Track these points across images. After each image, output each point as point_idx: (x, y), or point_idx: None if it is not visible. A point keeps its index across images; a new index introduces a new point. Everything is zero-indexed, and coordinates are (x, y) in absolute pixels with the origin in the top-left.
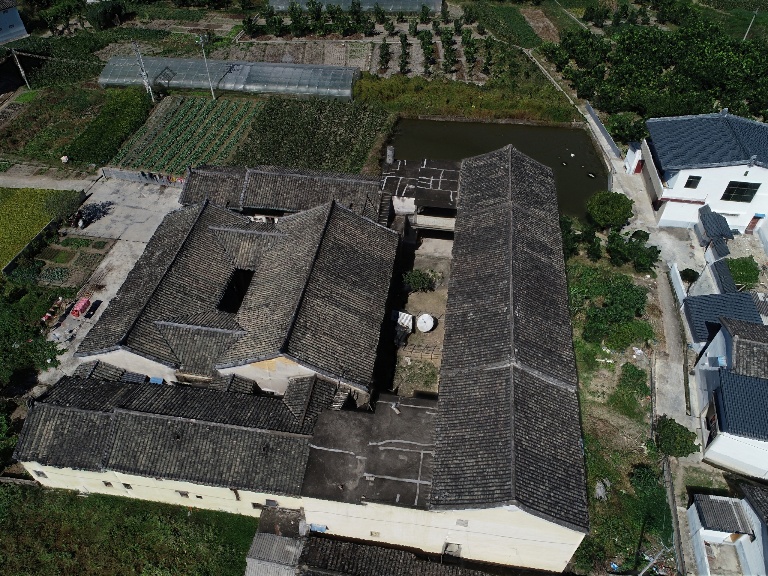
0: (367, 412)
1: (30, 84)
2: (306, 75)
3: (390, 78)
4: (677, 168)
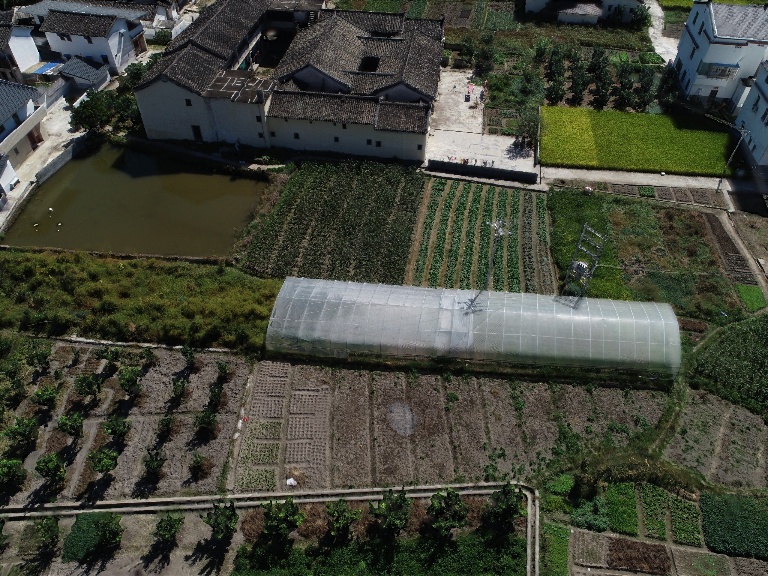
0: None
1: None
2: (352, 293)
3: (221, 322)
4: None
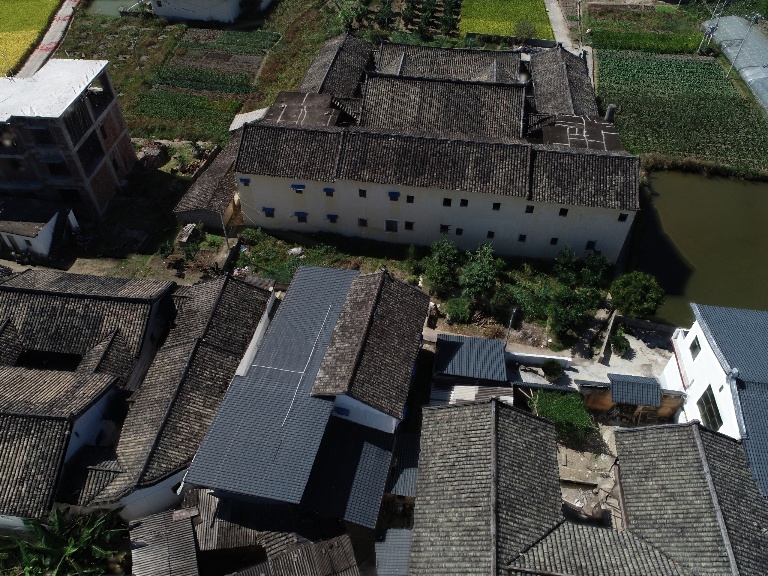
0: (339, 122)
1: (684, 6)
2: None
3: None
4: (695, 312)
